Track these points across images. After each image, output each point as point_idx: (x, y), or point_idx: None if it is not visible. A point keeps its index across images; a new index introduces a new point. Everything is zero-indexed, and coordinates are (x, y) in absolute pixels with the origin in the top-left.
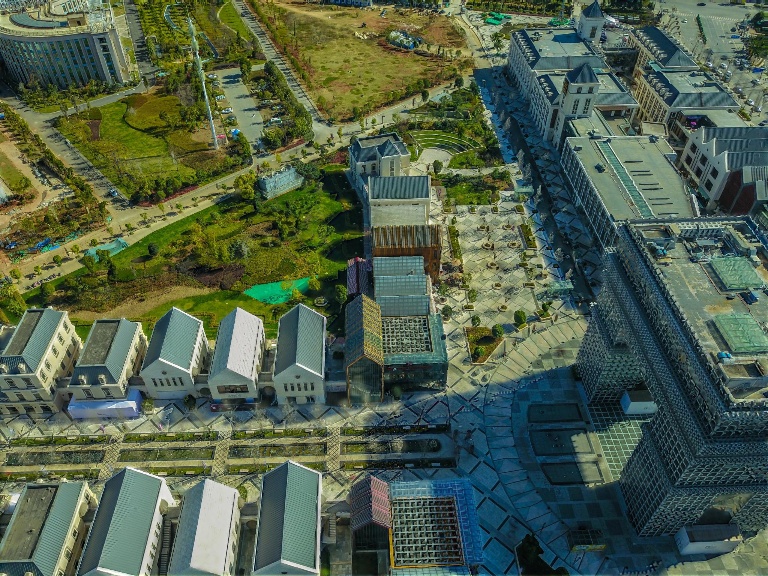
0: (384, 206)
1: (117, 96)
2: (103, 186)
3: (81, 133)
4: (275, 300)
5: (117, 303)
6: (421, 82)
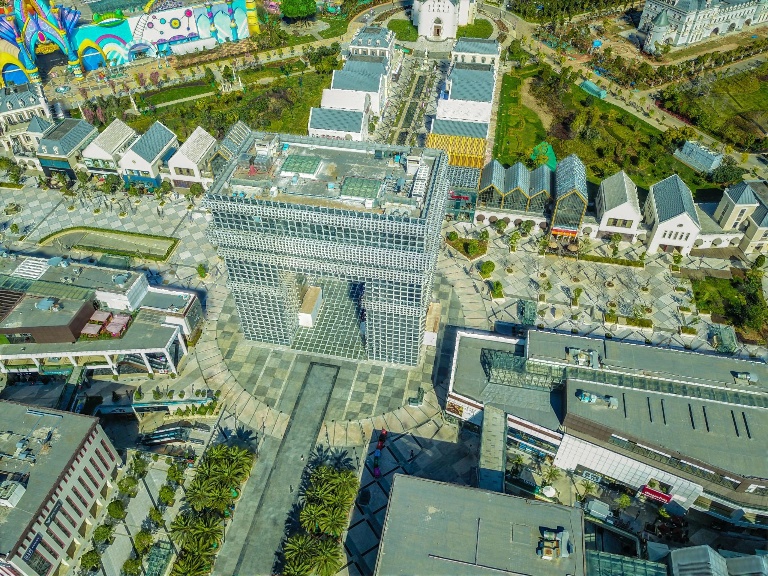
0: (624, 177)
1: None
2: (683, 86)
3: None
4: (534, 154)
5: (536, 96)
6: None
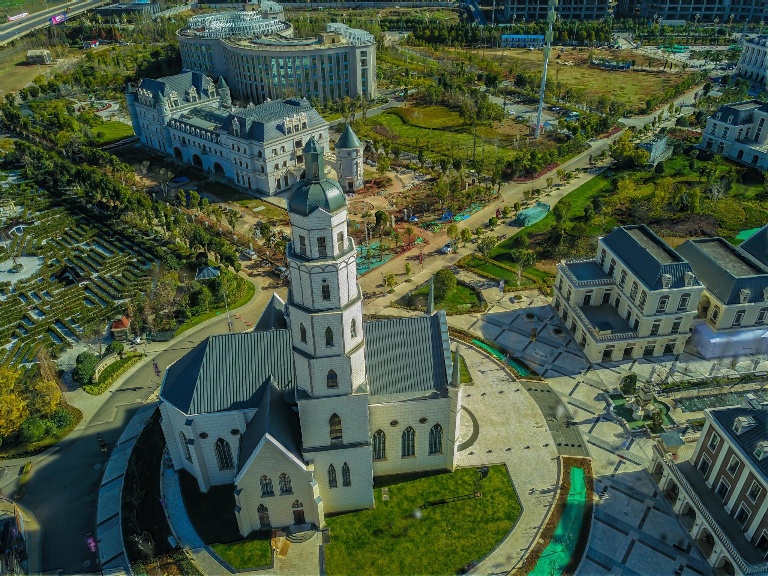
0: None
1: (376, 110)
2: None
3: (376, 135)
4: None
5: None
6: (685, 82)
